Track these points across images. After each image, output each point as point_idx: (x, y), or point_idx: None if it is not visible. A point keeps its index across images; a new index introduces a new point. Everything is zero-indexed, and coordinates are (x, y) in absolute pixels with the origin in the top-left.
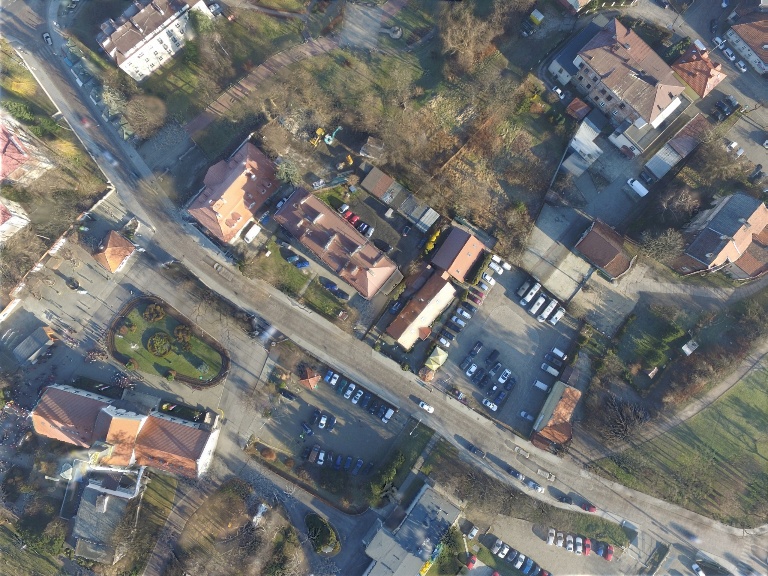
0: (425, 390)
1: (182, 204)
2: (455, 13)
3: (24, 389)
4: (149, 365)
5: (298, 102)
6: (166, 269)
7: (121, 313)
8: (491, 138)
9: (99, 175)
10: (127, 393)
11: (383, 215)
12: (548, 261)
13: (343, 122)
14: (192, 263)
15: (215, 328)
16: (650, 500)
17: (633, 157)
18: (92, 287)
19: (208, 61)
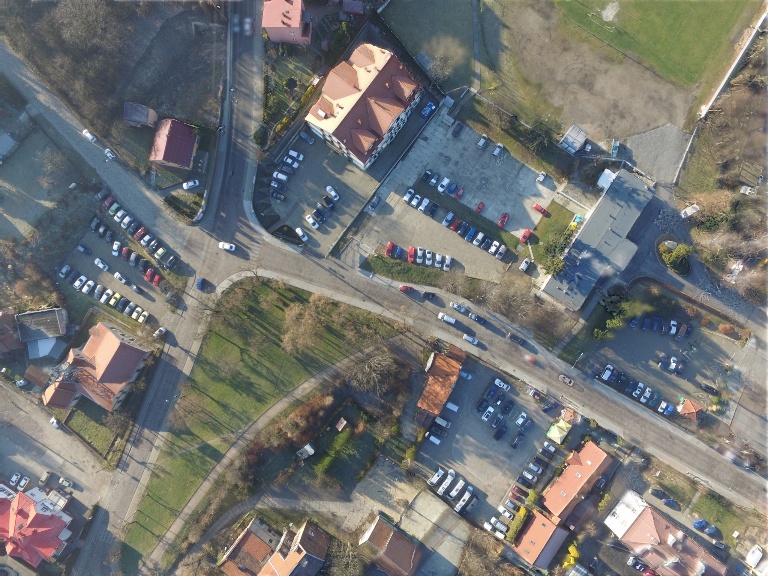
0: (568, 397)
1: None
2: None
3: None
4: None
5: None
6: None
7: None
8: None
9: None
10: None
11: None
12: (443, 531)
13: None
14: None
15: None
16: (346, 299)
17: None
18: None
19: None
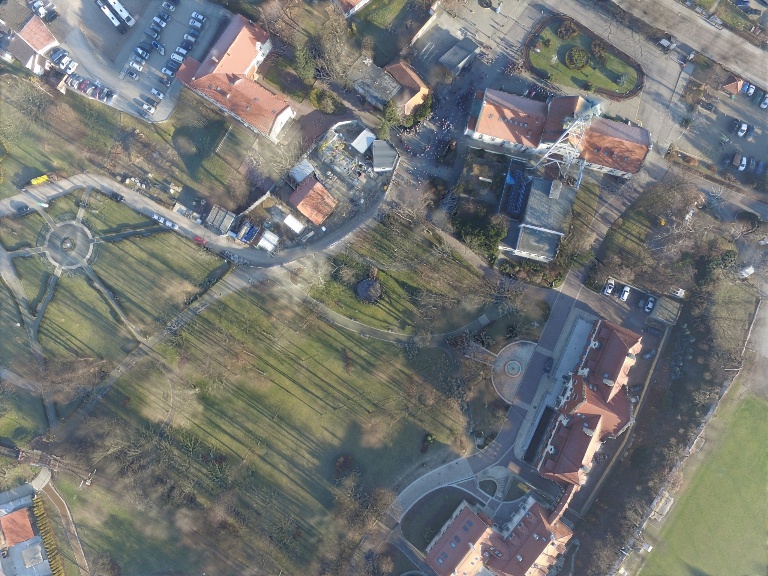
0: None
1: None
2: None
3: (442, 103)
4: (566, 79)
5: None
6: None
7: (534, 31)
8: None
9: None
10: None
11: None
12: None
13: None
14: None
15: (628, 45)
16: None
17: None
18: (503, 7)
19: None
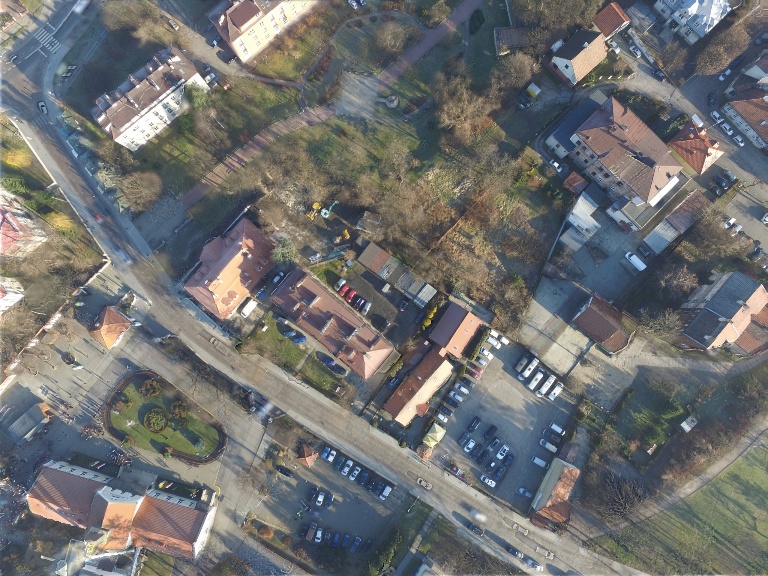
0: (423, 466)
1: (178, 278)
2: (452, 88)
3: (20, 465)
4: (145, 441)
5: (294, 174)
6: (162, 343)
7: (117, 388)
8: (488, 210)
9: (95, 248)
10: (123, 470)
11: (380, 289)
12: (546, 335)
13: (340, 196)
14: (188, 337)
15: (212, 403)
16: None
17: (631, 232)
18: (88, 362)
19: (204, 132)
